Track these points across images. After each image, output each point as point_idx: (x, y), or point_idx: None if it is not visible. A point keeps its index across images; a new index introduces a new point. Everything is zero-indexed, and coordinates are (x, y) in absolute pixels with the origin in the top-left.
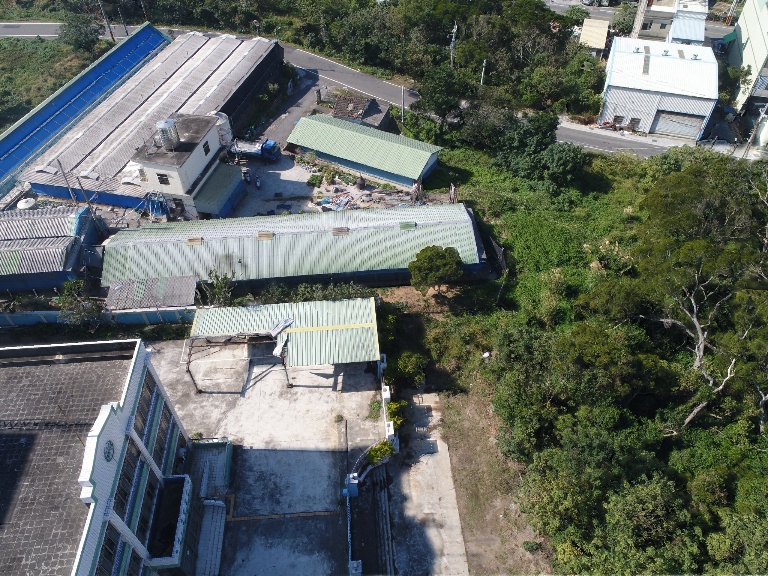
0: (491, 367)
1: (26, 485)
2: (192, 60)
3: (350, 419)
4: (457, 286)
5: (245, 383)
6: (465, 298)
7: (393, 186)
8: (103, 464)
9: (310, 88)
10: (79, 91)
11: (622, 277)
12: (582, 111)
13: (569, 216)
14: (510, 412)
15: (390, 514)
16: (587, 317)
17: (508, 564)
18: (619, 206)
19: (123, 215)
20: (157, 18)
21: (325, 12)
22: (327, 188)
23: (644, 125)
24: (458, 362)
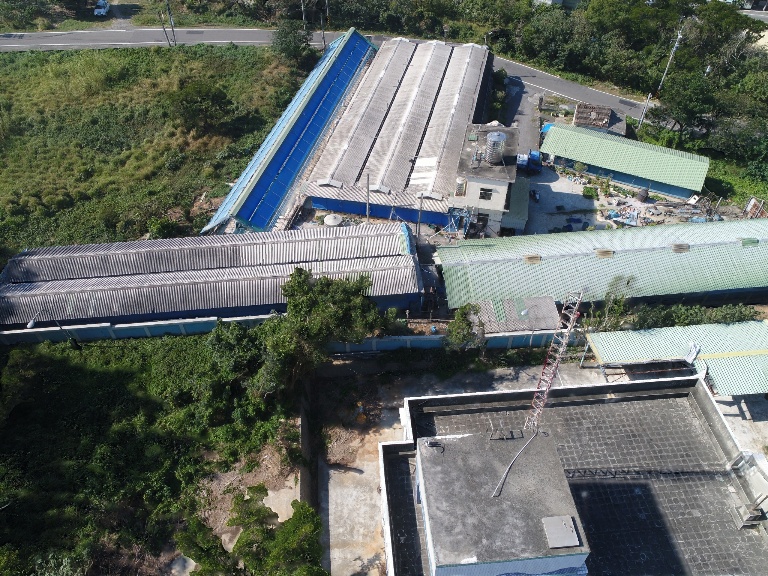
0: None
1: (682, 543)
2: (413, 67)
3: None
4: None
5: None
6: None
7: (664, 198)
8: None
9: (521, 95)
10: (320, 100)
11: None
12: None
13: None
14: None
15: None
16: None
17: None
18: None
19: None
20: (339, 23)
21: (525, 17)
22: (610, 201)
23: None
24: None
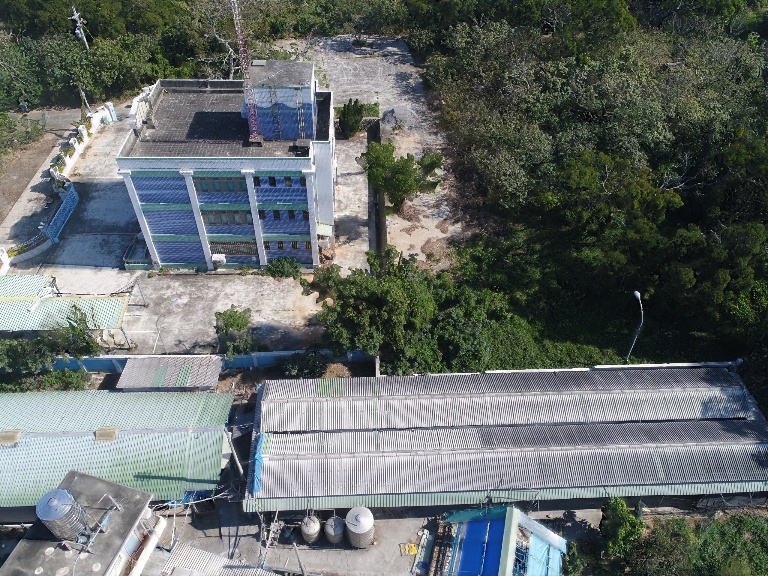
0: None
1: None
2: None
3: None
4: None
5: None
6: None
7: None
8: None
9: None
10: None
11: None
12: None
13: None
14: None
15: None
16: None
17: None
18: None
19: None
20: None
21: None
22: None
23: None
24: None
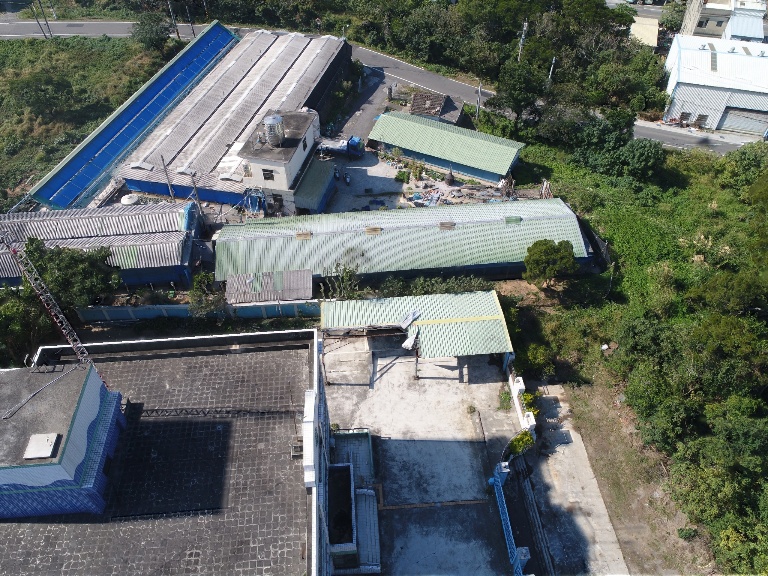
0: (623, 358)
1: (234, 471)
2: (265, 58)
3: (482, 410)
4: (563, 280)
5: (372, 375)
6: (574, 291)
7: (478, 182)
8: (315, 449)
9: (378, 86)
10: (160, 88)
11: (719, 271)
12: (647, 108)
13: (655, 211)
14: (649, 402)
15: (536, 503)
16: (698, 310)
17: (662, 551)
18: (699, 201)
19: (220, 211)
20: (218, 16)
21: (390, 10)
22: (417, 184)
23: (711, 122)
24: (579, 354)
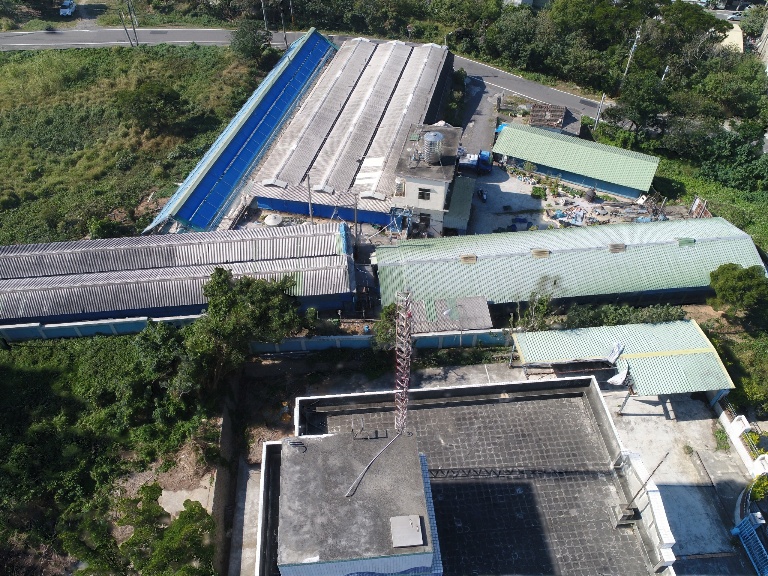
0: None
1: (556, 543)
2: (371, 67)
3: (700, 450)
4: None
5: None
6: (757, 318)
7: (614, 198)
8: None
9: (481, 95)
10: (273, 100)
11: None
12: None
13: None
14: None
15: None
16: None
17: None
18: None
19: (360, 231)
20: (303, 23)
21: (488, 17)
22: (557, 201)
23: None
24: None
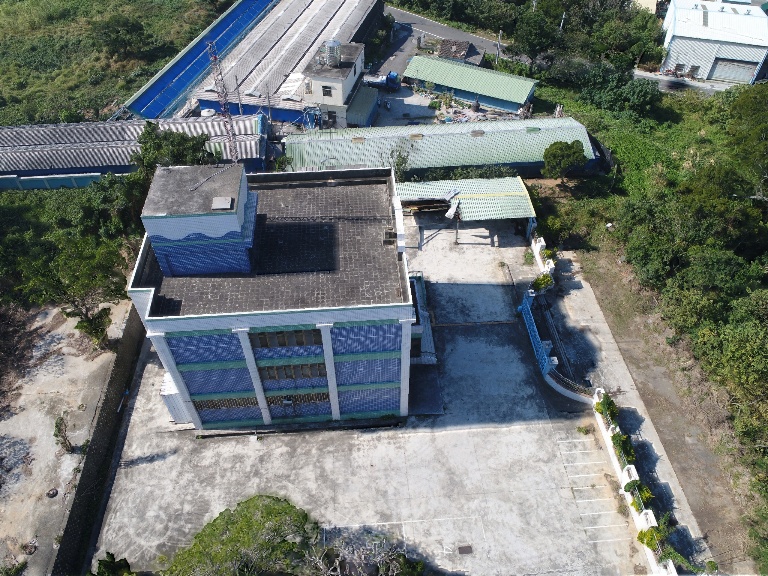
0: (624, 223)
1: (341, 251)
2: (309, 9)
3: (510, 265)
4: (575, 179)
5: (420, 241)
6: (583, 187)
7: None
8: None
9: (407, 38)
10: (221, 31)
11: None
12: (646, 61)
13: (651, 137)
14: (645, 252)
15: (555, 326)
16: None
17: (653, 356)
18: None
19: None
20: None
21: None
22: (447, 110)
23: (703, 72)
24: (588, 229)
